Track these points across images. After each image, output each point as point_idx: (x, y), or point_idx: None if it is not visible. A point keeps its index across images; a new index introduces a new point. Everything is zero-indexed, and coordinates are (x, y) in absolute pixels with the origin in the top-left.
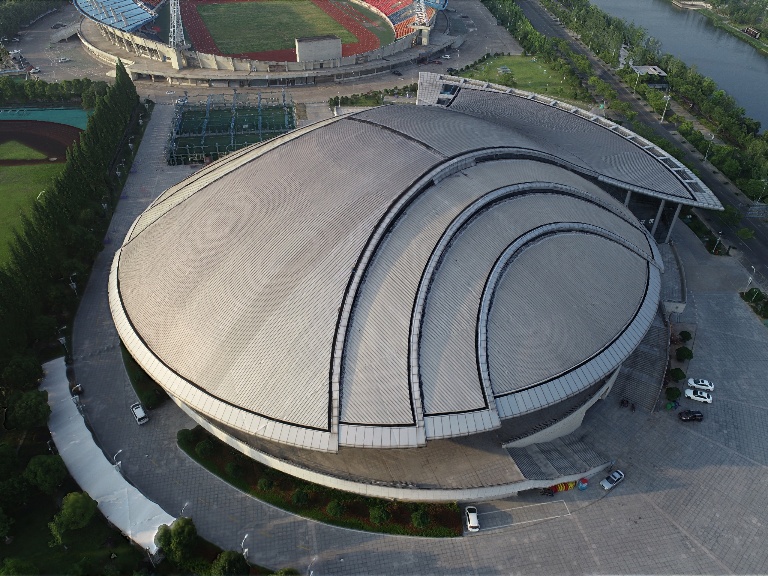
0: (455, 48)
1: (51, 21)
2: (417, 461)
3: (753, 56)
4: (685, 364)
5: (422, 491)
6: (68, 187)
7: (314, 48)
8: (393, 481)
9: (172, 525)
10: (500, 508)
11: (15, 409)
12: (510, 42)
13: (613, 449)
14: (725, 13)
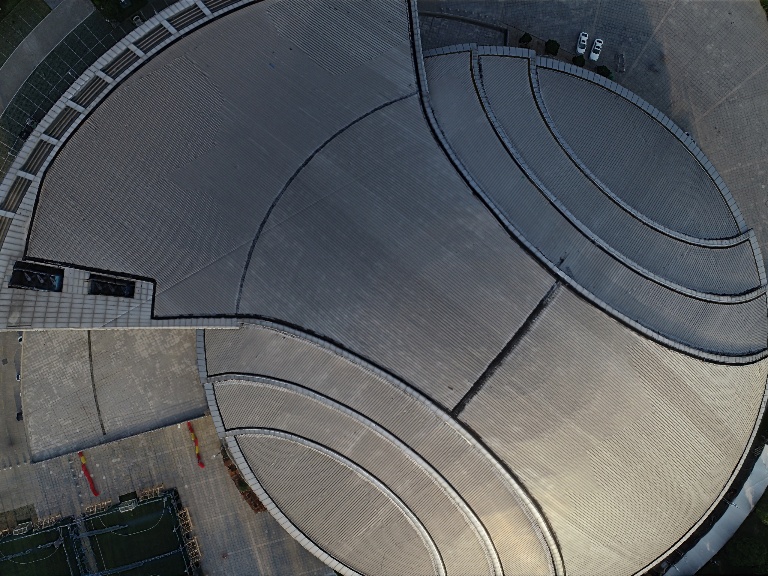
0: None
1: None
2: None
3: None
4: None
5: None
6: None
7: None
8: None
9: None
10: None
11: None
12: None
13: None
14: None
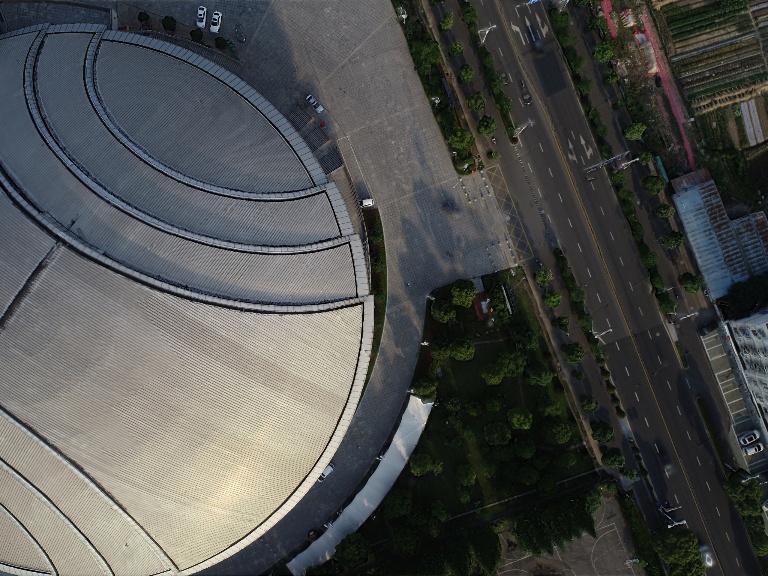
0: None
1: None
2: None
3: None
4: (177, 25)
5: None
6: None
7: None
8: None
9: None
10: None
11: None
12: None
13: (285, 100)
14: None
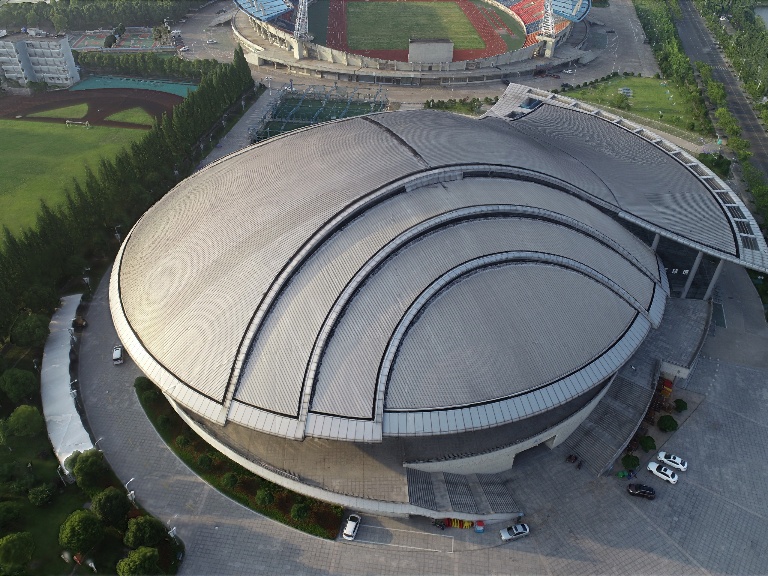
0: (583, 63)
1: (218, 7)
2: (315, 456)
3: None
4: (667, 435)
5: (303, 485)
6: (145, 151)
7: (425, 50)
8: (283, 468)
9: (82, 453)
10: (385, 525)
11: (17, 327)
12: (649, 62)
13: (534, 501)
14: None
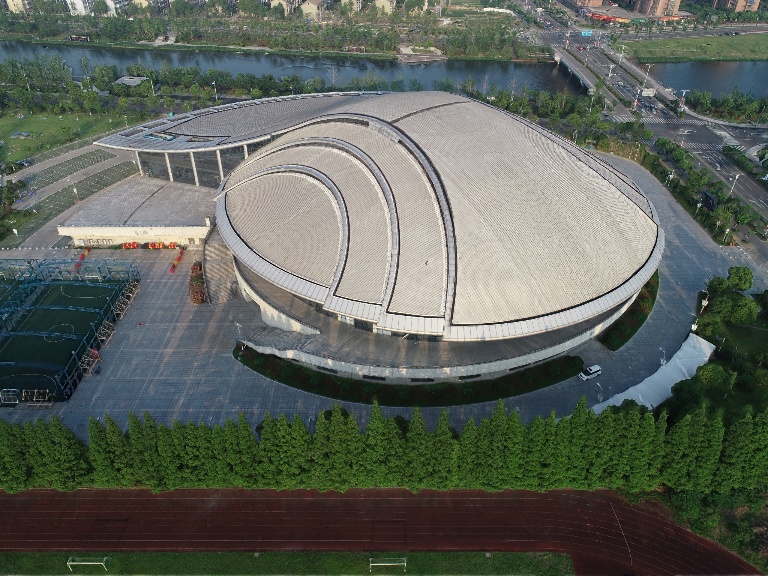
0: None
1: None
2: None
3: (92, 57)
4: None
5: None
6: None
7: None
8: None
9: (708, 321)
10: None
11: None
12: None
13: None
14: (24, 32)
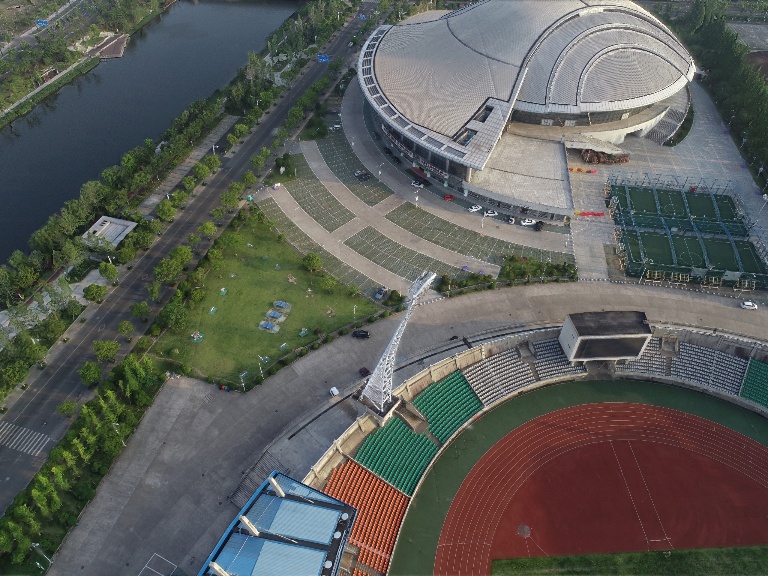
0: None
1: None
2: None
3: None
4: None
5: None
6: None
7: None
8: None
9: None
10: None
11: None
12: (134, 462)
13: None
14: None
